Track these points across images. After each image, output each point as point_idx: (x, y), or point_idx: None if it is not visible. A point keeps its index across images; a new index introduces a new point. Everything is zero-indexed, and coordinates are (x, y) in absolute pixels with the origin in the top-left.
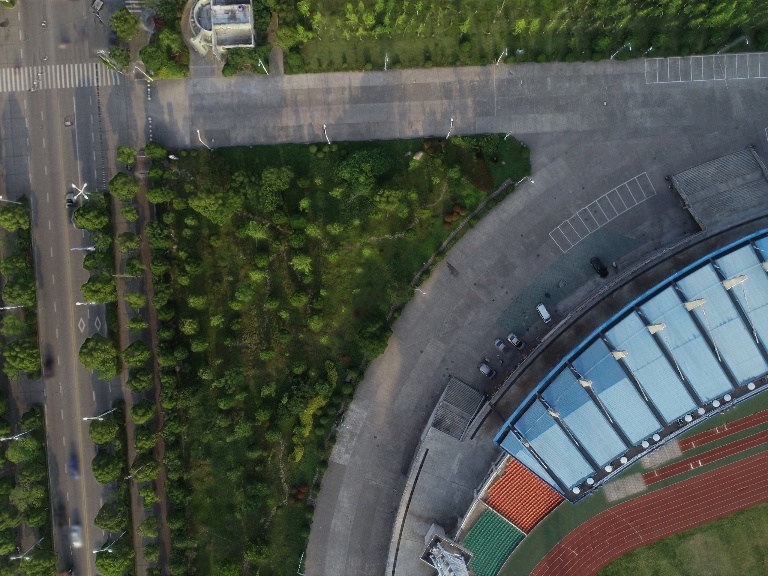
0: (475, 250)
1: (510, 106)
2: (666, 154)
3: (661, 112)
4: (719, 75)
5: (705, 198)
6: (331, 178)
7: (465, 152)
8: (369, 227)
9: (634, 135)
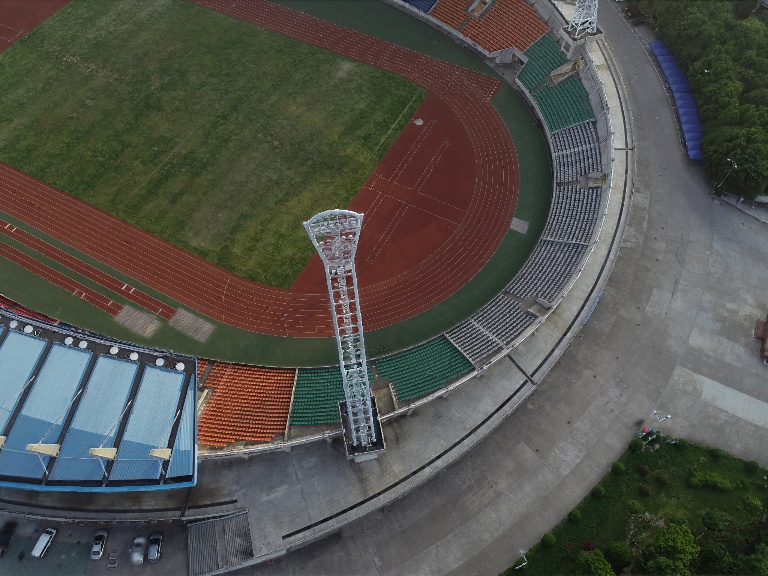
0: None
1: None
2: None
3: None
4: None
5: None
6: None
7: None
8: None
9: None
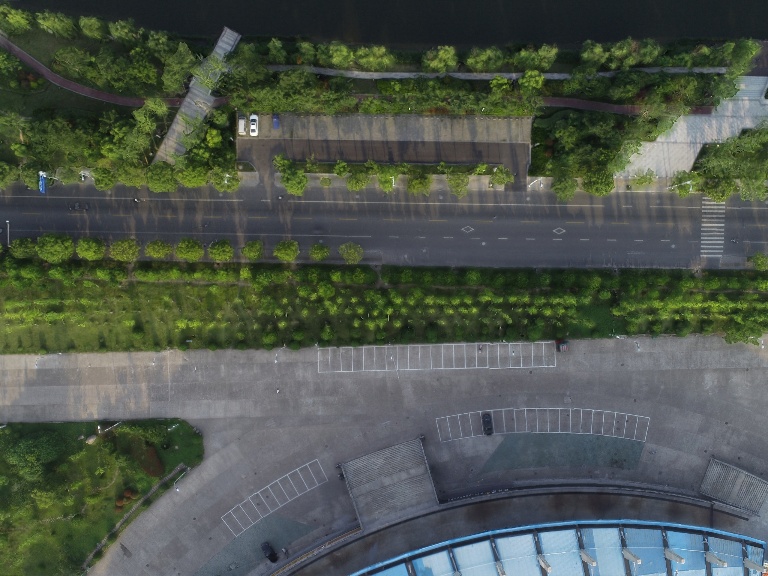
0: (148, 532)
1: (184, 392)
2: (338, 442)
3: (333, 401)
4: (391, 366)
5: (369, 491)
6: (5, 460)
7: (136, 439)
8: (41, 509)
9: (306, 422)
